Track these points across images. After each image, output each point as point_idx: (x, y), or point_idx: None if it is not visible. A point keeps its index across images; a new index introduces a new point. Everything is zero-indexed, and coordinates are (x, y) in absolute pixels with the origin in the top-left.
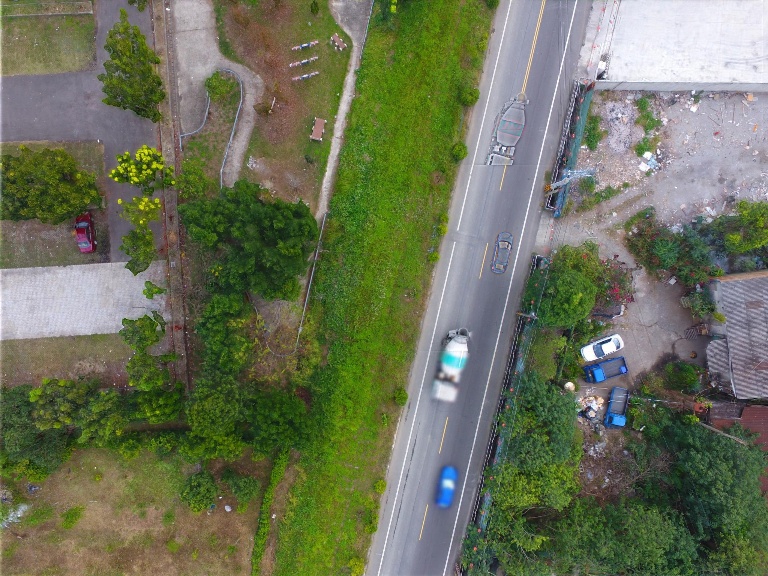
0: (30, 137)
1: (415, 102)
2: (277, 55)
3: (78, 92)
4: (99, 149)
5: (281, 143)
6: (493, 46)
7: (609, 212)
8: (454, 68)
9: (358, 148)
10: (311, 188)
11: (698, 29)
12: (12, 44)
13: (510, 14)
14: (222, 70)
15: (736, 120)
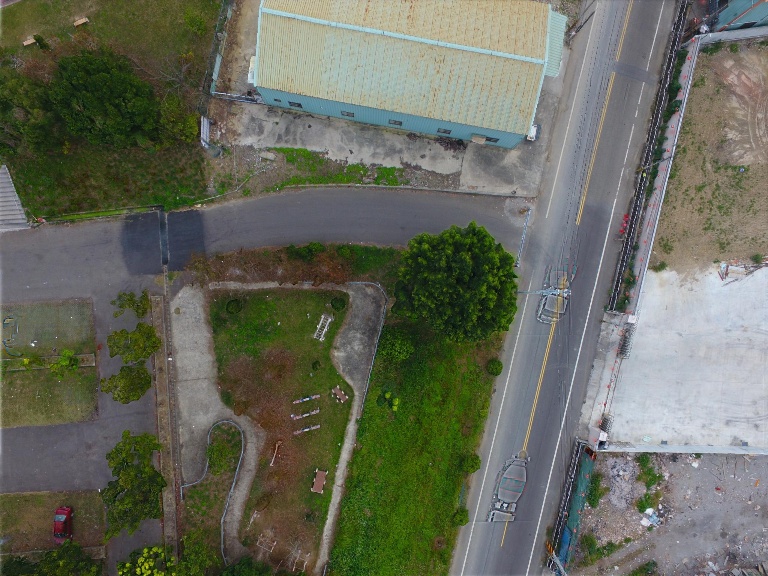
0: (31, 488)
1: (416, 470)
2: (279, 406)
3: (79, 443)
4: (100, 499)
5: (282, 493)
6: (494, 406)
7: (611, 566)
8: (455, 436)
9: (359, 503)
10: (312, 537)
11: (699, 388)
12: (14, 396)
13: (511, 374)
14: (224, 422)
15: (738, 475)
